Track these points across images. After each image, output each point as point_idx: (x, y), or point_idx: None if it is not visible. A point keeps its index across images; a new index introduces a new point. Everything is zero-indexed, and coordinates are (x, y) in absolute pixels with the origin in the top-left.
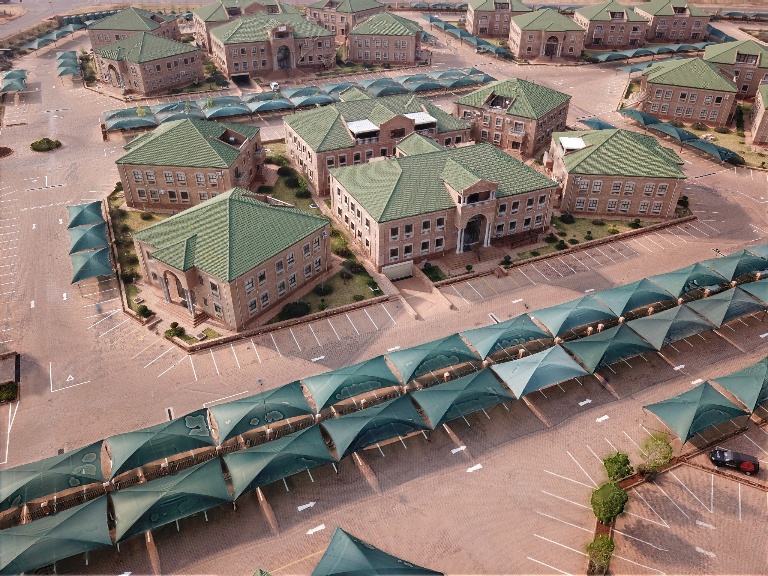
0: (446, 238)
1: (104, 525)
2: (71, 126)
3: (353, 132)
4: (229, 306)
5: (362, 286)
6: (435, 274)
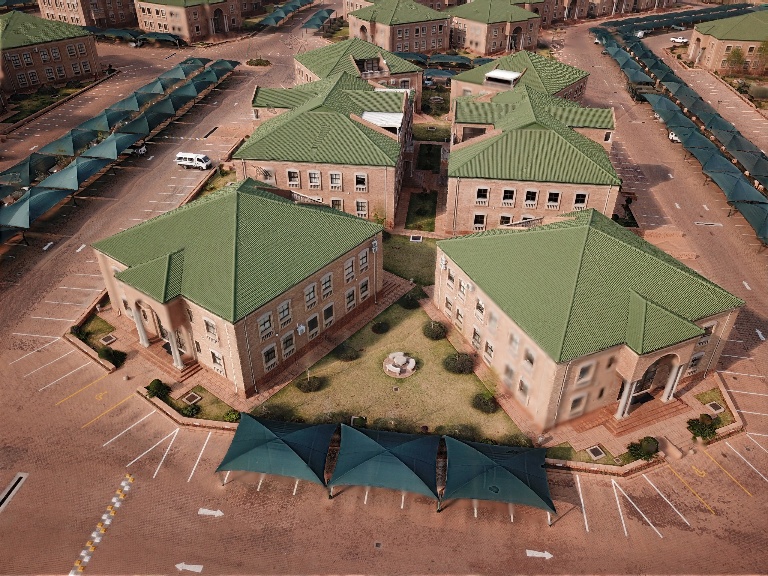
0: None
1: None
2: None
3: (393, 127)
4: (721, 343)
5: None
6: (633, 219)
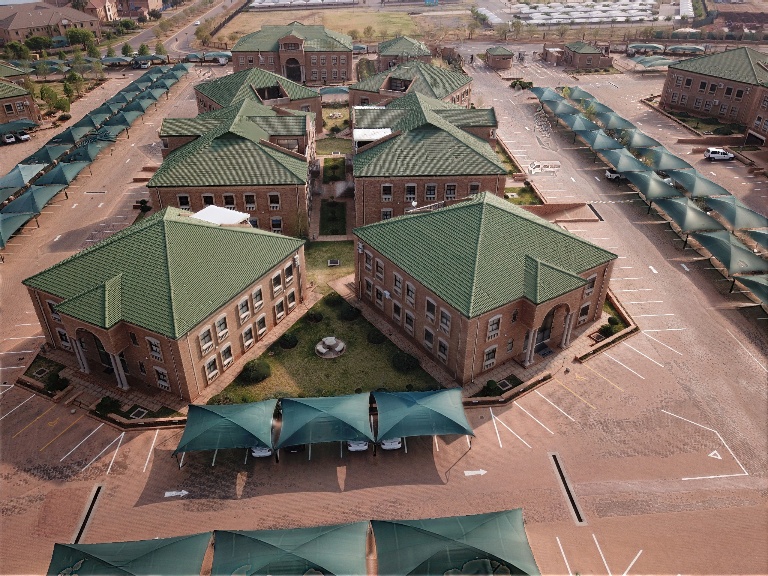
0: None
1: (115, 102)
2: None
3: None
4: None
5: None
6: None
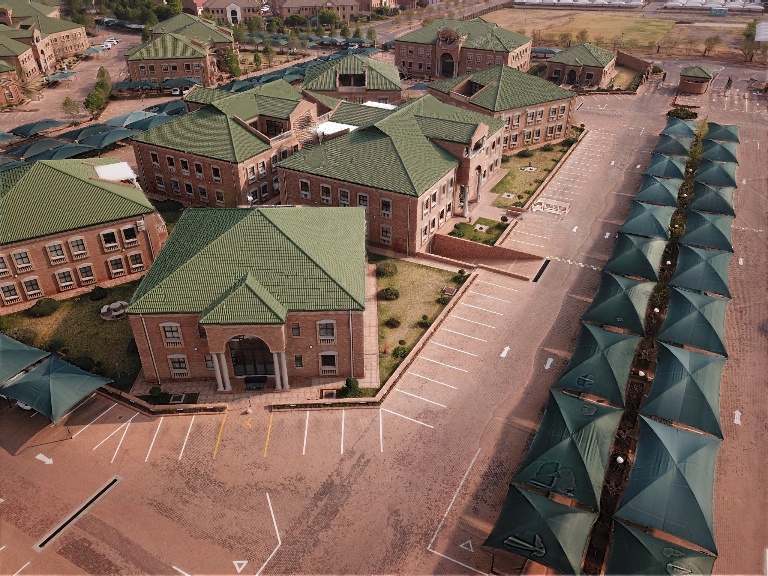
0: None
1: None
2: (741, 130)
3: None
4: None
5: None
6: None
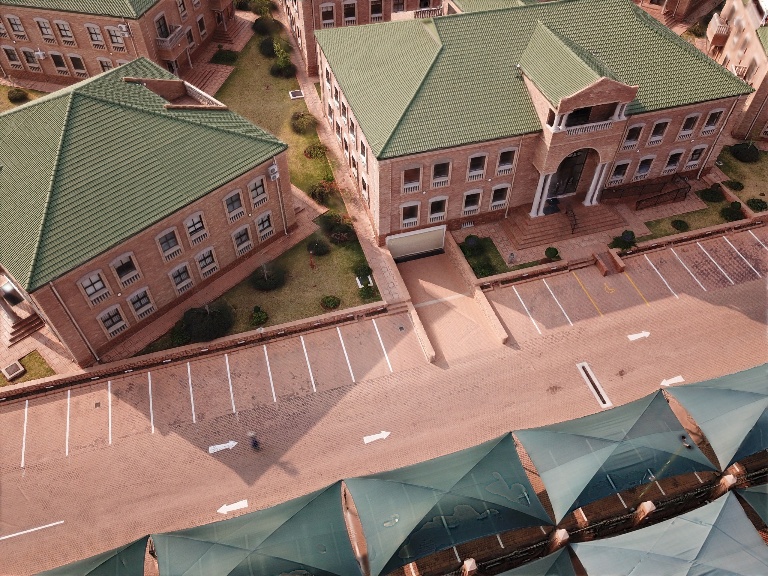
0: (514, 187)
1: None
2: None
3: None
4: (52, 327)
5: (343, 274)
6: (483, 262)
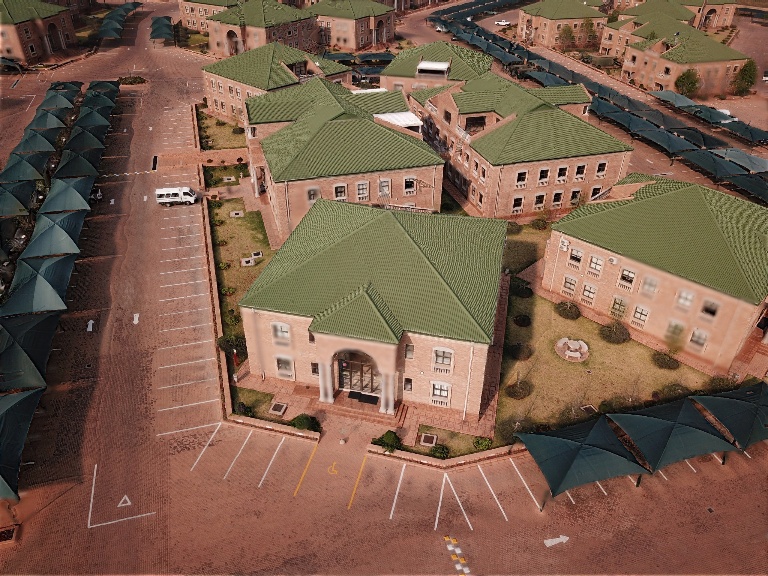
0: None
1: None
2: None
3: (416, 126)
4: None
5: None
6: None
